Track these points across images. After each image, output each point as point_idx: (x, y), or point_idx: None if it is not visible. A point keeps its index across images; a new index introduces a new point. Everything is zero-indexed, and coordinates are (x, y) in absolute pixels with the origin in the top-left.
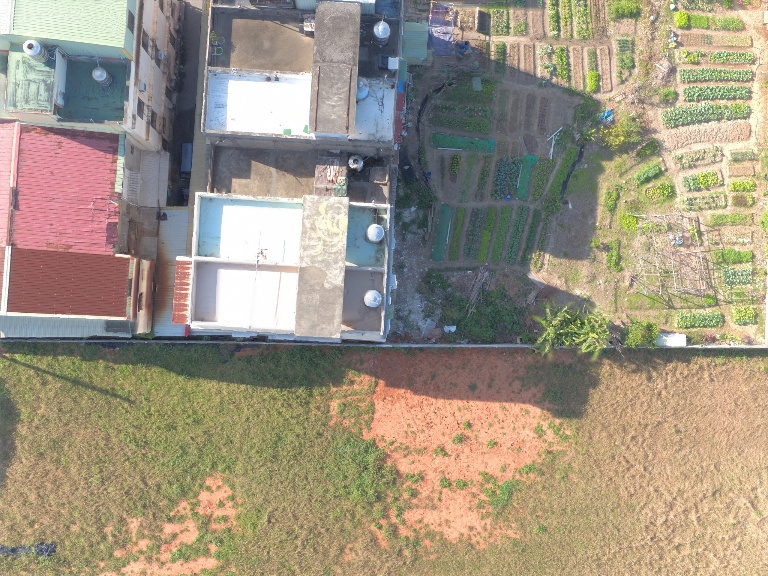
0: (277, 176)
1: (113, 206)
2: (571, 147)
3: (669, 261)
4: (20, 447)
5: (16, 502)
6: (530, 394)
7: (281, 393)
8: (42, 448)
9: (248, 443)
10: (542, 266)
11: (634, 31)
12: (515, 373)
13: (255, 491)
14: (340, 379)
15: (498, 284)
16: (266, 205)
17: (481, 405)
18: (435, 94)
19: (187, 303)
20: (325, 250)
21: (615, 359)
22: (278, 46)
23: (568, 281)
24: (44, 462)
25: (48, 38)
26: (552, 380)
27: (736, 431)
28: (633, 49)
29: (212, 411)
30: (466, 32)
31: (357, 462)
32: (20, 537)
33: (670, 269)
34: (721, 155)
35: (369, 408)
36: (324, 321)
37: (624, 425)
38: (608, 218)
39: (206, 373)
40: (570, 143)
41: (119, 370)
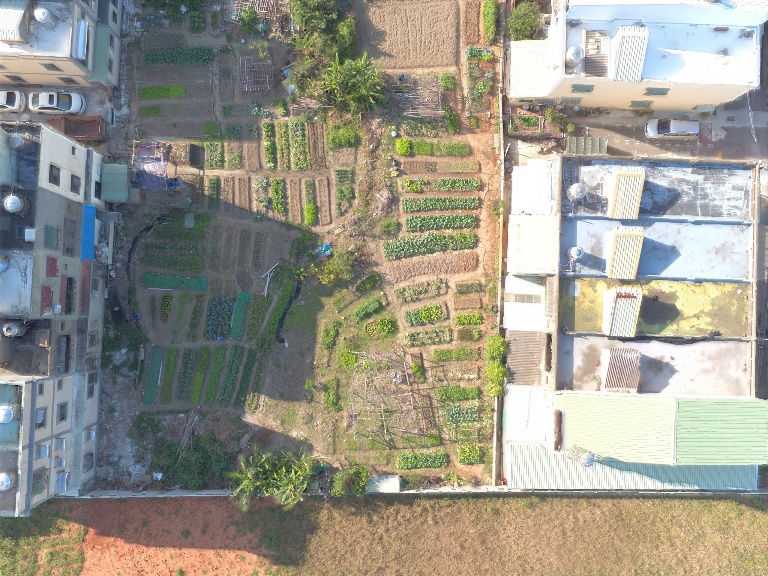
0: None
1: None
2: (287, 283)
3: (390, 400)
4: None
5: None
6: (245, 540)
7: None
8: None
9: None
10: (257, 408)
11: (354, 160)
12: (230, 518)
13: None
14: (47, 528)
15: (206, 429)
16: None
17: (194, 552)
18: (145, 233)
19: None
20: None
21: (334, 502)
22: None
23: (284, 422)
24: None
25: None
26: (267, 525)
27: (462, 575)
28: (353, 179)
29: None
30: (179, 167)
31: None
32: None
33: (391, 408)
34: (446, 287)
35: (78, 557)
36: None
37: (343, 571)
38: (326, 356)
39: None
40: (287, 279)
41: None
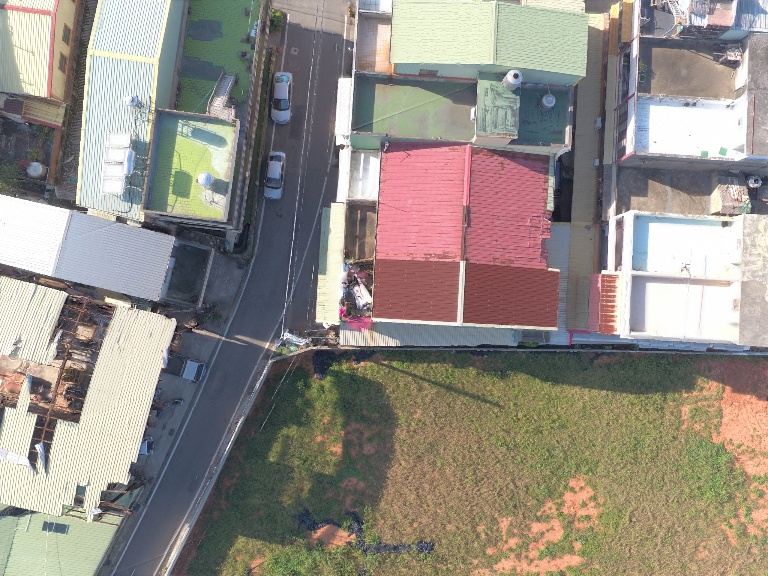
0: (672, 194)
1: (546, 223)
2: None
3: None
4: (399, 450)
5: (397, 502)
6: None
7: (639, 399)
8: (420, 451)
9: (609, 446)
10: None
11: None
12: None
13: (617, 492)
14: (691, 385)
15: None
16: (688, 222)
17: None
18: None
19: (614, 314)
20: (765, 265)
21: None
22: (694, 73)
23: None
24: (422, 464)
25: (524, 68)
26: None
27: None
28: None
29: (575, 416)
30: None
31: (710, 464)
32: (401, 536)
33: None
34: None
35: (718, 413)
36: (765, 332)
37: None
38: None
39: (569, 380)
40: None
41: (489, 377)
